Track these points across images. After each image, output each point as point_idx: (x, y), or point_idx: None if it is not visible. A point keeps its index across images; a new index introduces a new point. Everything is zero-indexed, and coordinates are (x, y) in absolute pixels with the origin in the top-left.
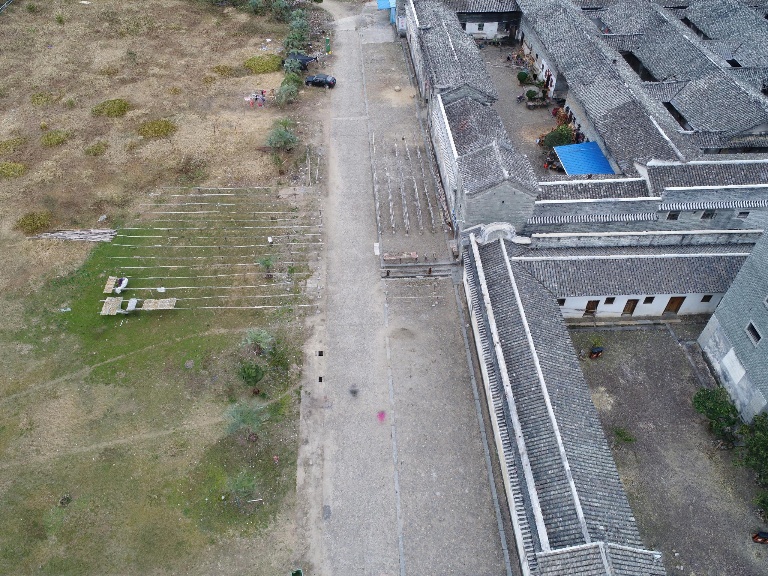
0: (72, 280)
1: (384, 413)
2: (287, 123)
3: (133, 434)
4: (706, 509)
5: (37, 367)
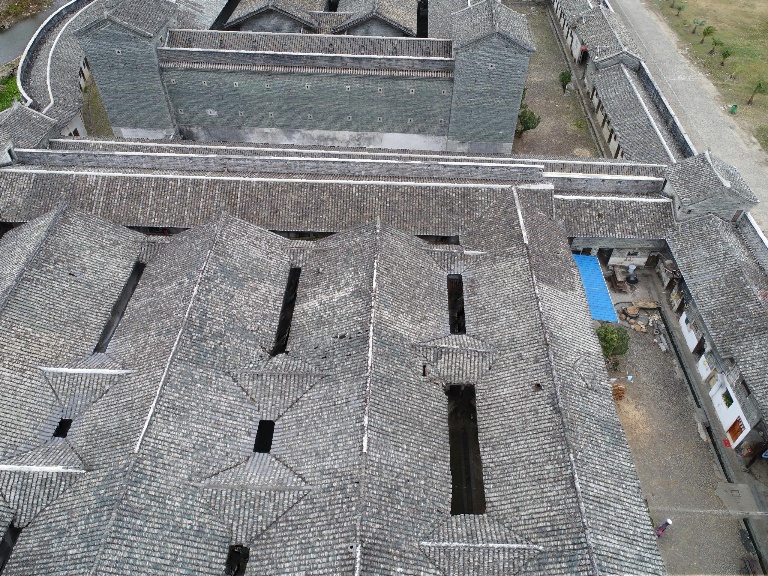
0: None
1: (719, 157)
2: None
3: None
4: (536, 115)
5: None
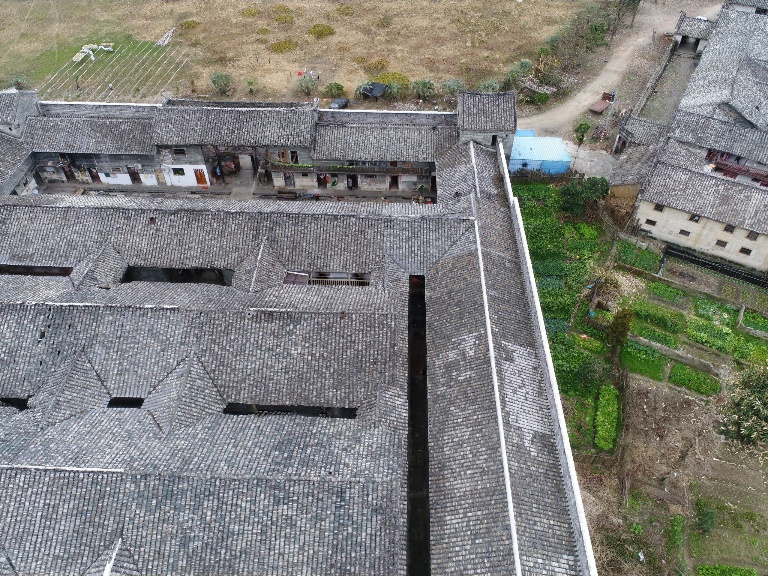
0: (128, 39)
1: None
2: (251, 84)
3: (2, 62)
4: None
5: (69, 39)
